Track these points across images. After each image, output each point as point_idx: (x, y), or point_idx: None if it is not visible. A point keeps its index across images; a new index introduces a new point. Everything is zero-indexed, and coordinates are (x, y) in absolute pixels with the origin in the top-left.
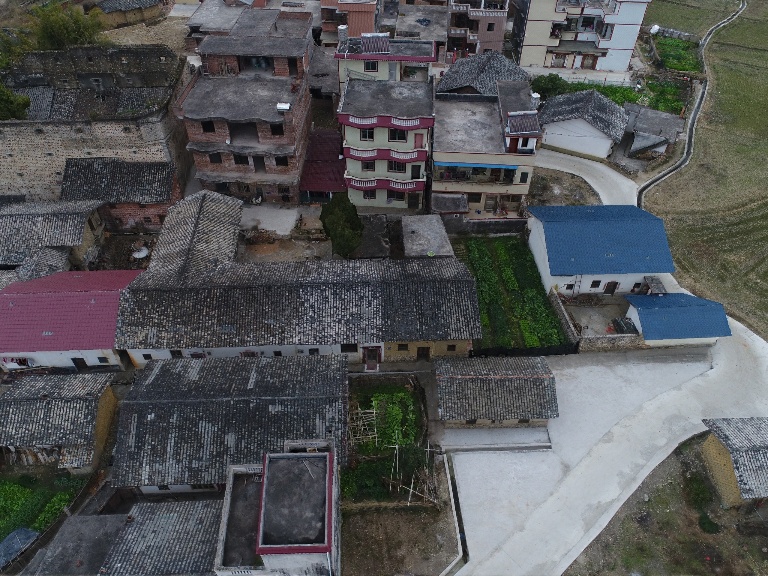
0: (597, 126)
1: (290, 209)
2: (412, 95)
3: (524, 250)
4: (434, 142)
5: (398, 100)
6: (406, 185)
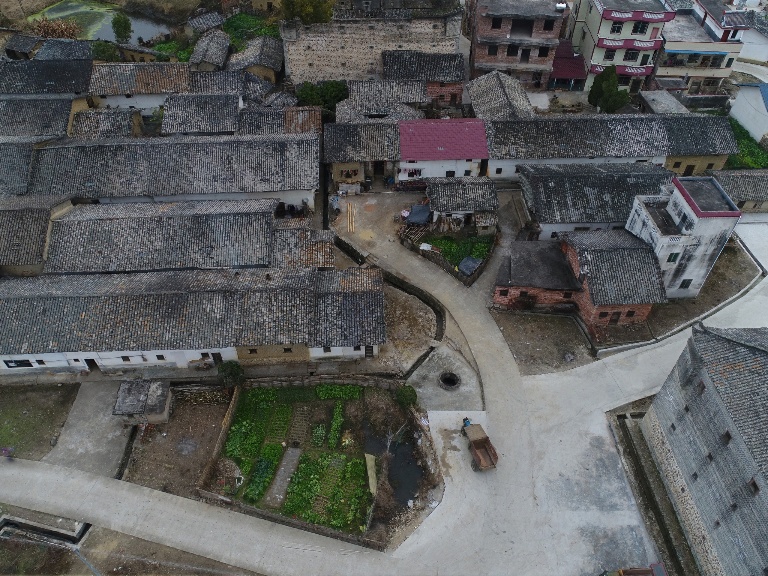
0: (765, 34)
1: (540, 93)
2: (645, 2)
3: (728, 118)
4: (664, 36)
5: (637, 4)
6: (639, 70)
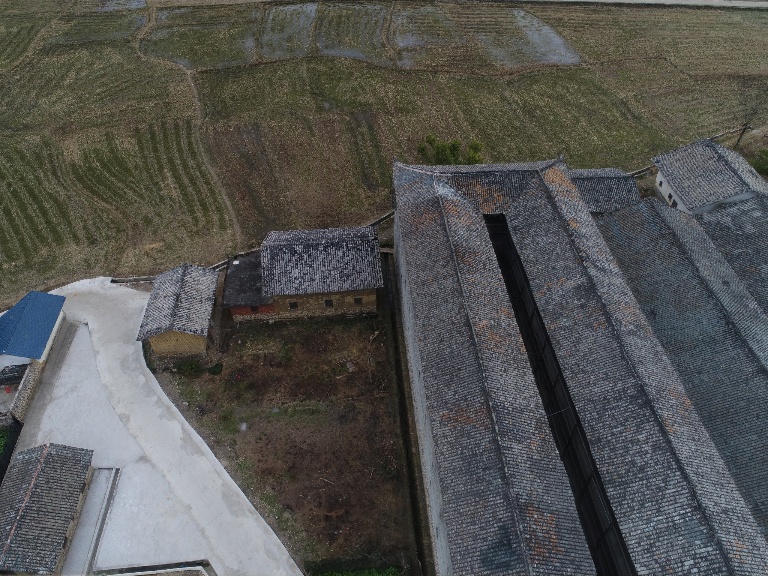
0: None
1: None
2: None
3: None
4: None
5: None
6: None
